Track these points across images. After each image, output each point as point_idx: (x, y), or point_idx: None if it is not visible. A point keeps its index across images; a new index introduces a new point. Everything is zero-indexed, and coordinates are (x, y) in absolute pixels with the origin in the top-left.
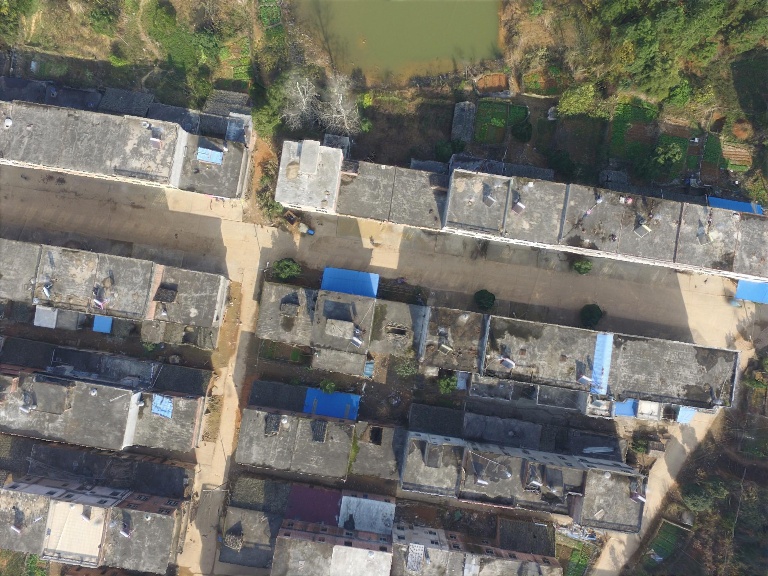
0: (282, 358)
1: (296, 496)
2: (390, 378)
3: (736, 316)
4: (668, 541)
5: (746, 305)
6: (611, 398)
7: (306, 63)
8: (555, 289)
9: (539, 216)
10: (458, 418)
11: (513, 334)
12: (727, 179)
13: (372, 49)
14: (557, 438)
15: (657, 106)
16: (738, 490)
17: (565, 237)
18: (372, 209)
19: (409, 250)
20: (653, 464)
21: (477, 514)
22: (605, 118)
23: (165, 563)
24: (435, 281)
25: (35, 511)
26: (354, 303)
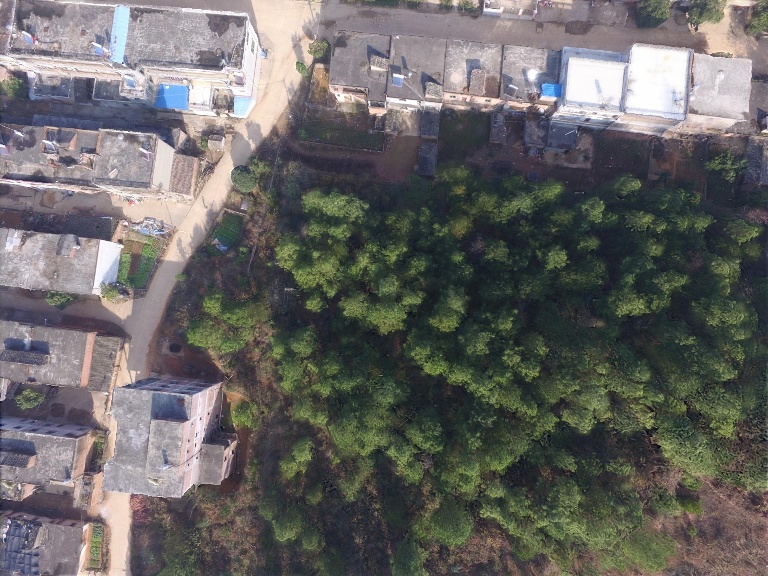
0: None
1: None
2: None
3: (302, 18)
4: (232, 231)
5: (312, 7)
6: None
7: None
8: None
9: None
10: None
11: (38, 14)
12: None
13: None
14: None
15: None
16: None
17: None
18: None
19: None
20: (220, 160)
21: (55, 215)
22: None
23: None
24: None
25: None
26: None
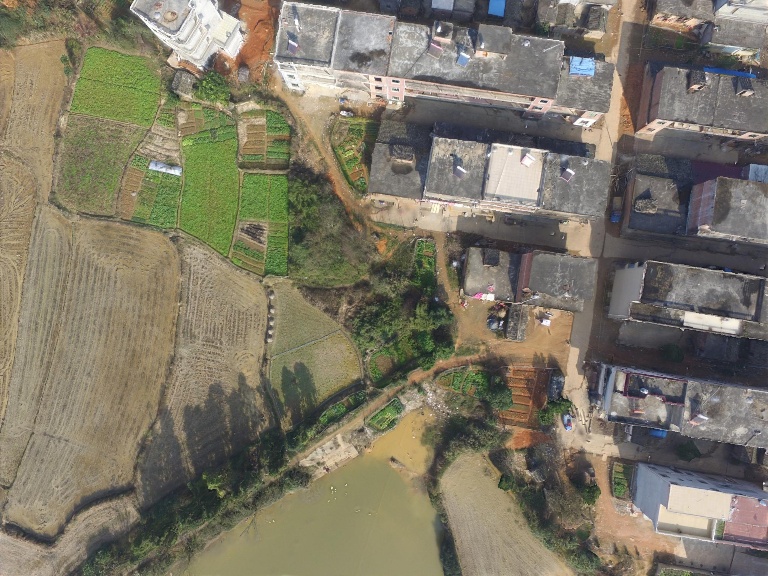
0: (667, 46)
1: (699, 168)
2: None
3: None
4: None
5: None
6: None
7: None
8: None
9: None
10: None
11: None
12: None
13: None
14: None
15: None
16: None
17: None
18: None
19: None
20: None
21: None
22: None
23: (603, 206)
24: None
25: (473, 158)
26: None
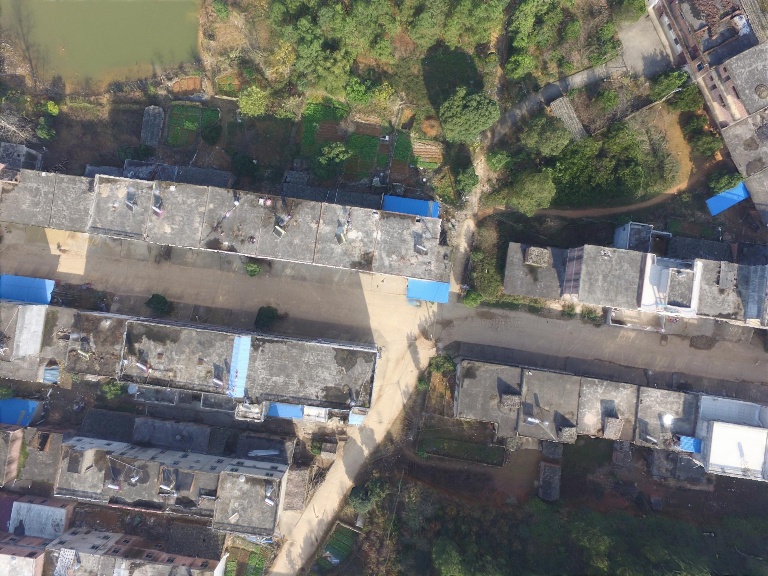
0: None
1: None
2: (76, 383)
3: (418, 315)
4: (344, 543)
5: (428, 304)
6: (245, 401)
7: (6, 72)
8: (238, 292)
9: (181, 220)
10: (132, 422)
11: (151, 338)
12: (417, 177)
13: (72, 56)
14: (229, 441)
15: (347, 105)
16: (403, 491)
17: (204, 240)
18: (33, 216)
19: (96, 256)
20: (331, 466)
21: (155, 518)
22: (291, 118)
23: None
24: (121, 286)
25: None
26: None
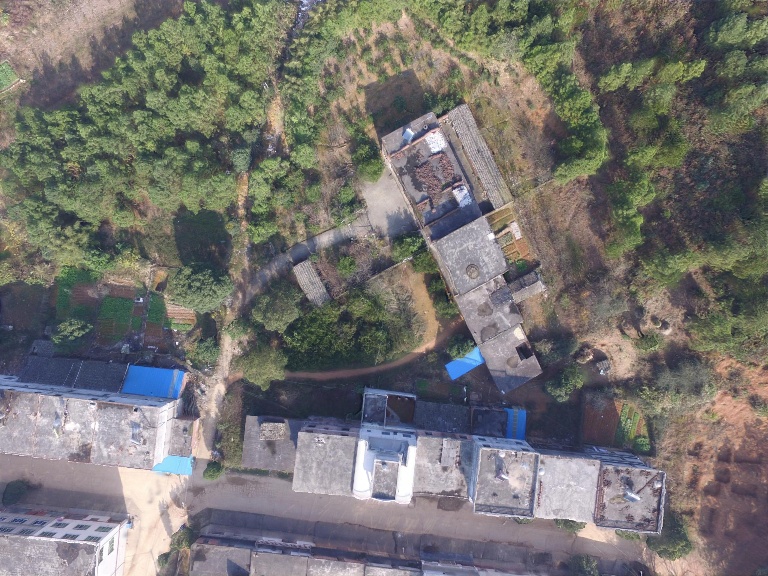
0: None
1: None
2: None
3: (169, 483)
4: None
5: None
6: None
7: None
8: None
9: None
10: None
11: None
12: (171, 339)
13: None
14: None
15: None
16: None
17: None
18: None
19: None
20: None
21: None
22: (43, 285)
23: None
24: None
25: None
26: None
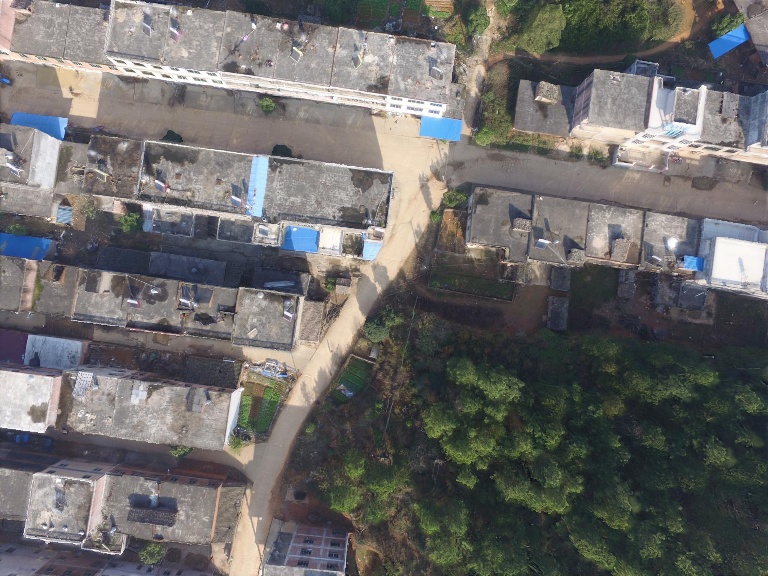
0: None
1: None
2: (89, 225)
3: (430, 157)
4: (358, 376)
5: (440, 146)
6: (263, 219)
7: None
8: (252, 134)
9: (198, 44)
10: (147, 259)
11: (169, 159)
12: (428, 25)
13: None
14: (244, 276)
15: None
16: (416, 320)
17: (221, 63)
18: (47, 47)
19: (108, 99)
20: (345, 302)
21: (170, 354)
22: None
23: None
24: (134, 129)
25: None
26: (15, 133)
